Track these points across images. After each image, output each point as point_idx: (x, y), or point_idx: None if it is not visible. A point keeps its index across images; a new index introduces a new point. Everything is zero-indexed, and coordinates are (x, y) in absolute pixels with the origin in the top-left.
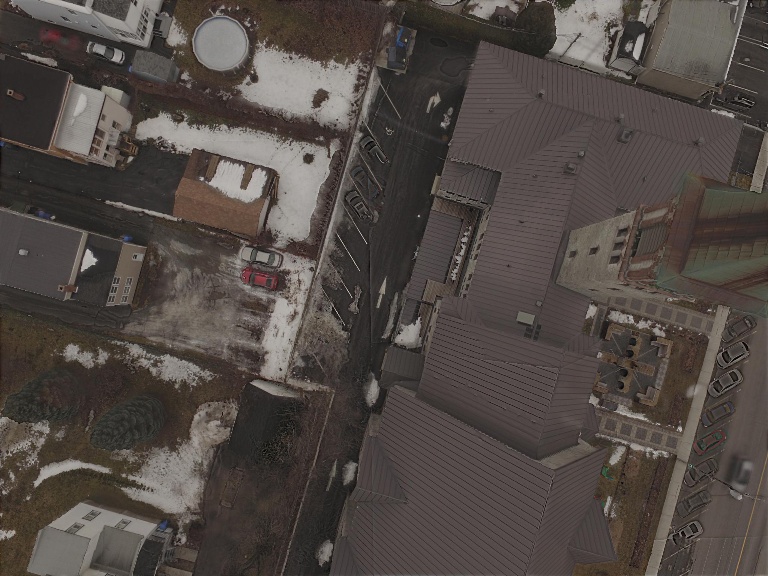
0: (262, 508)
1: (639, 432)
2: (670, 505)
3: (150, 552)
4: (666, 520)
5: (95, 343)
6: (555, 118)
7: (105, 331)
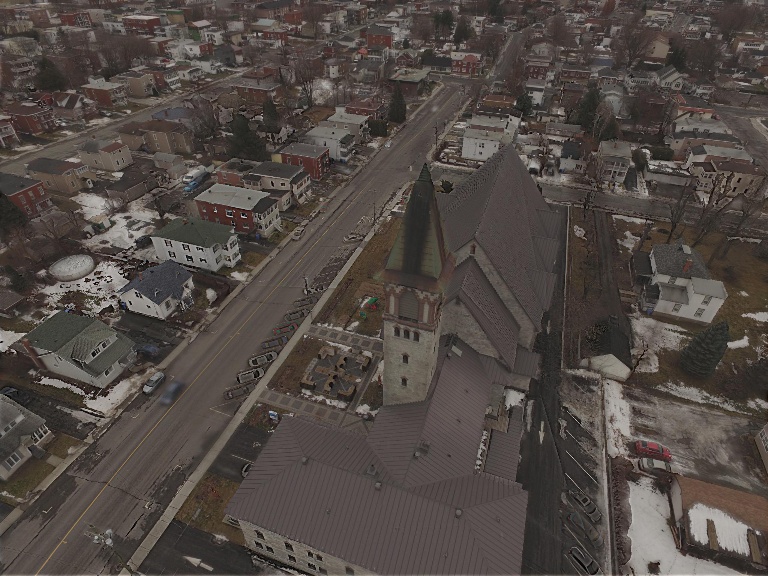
0: (589, 316)
1: (335, 336)
2: (322, 302)
3: (653, 293)
4: (326, 296)
5: (765, 415)
6: (439, 495)
7: (763, 421)
